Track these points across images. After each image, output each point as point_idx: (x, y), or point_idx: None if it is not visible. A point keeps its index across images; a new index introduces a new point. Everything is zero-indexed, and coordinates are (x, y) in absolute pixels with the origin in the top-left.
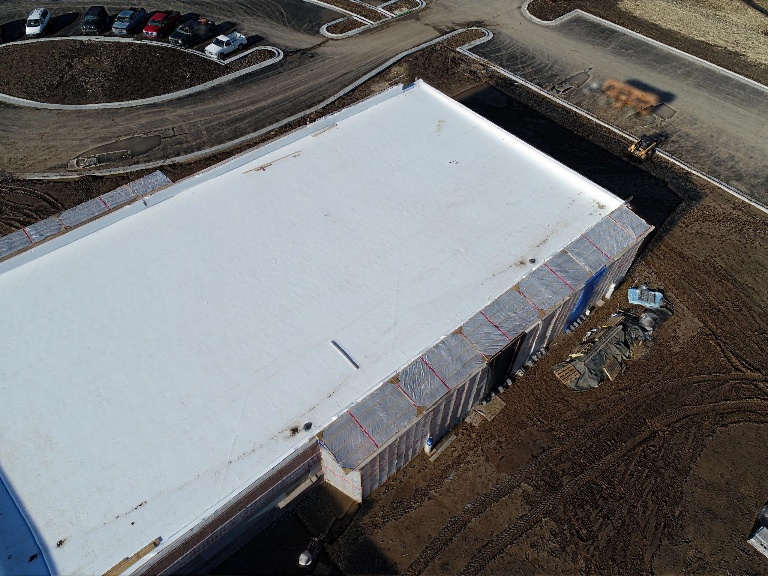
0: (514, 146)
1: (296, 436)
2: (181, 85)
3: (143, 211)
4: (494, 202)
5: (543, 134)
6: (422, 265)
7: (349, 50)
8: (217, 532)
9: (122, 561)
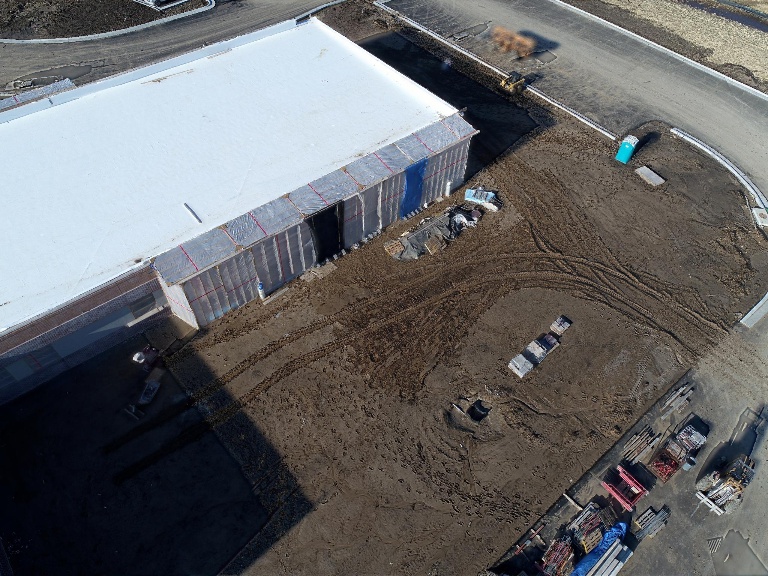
0: (382, 70)
1: None
2: (118, 26)
3: (49, 108)
4: (351, 111)
5: (429, 71)
6: (275, 154)
7: (276, 2)
8: (64, 326)
9: None
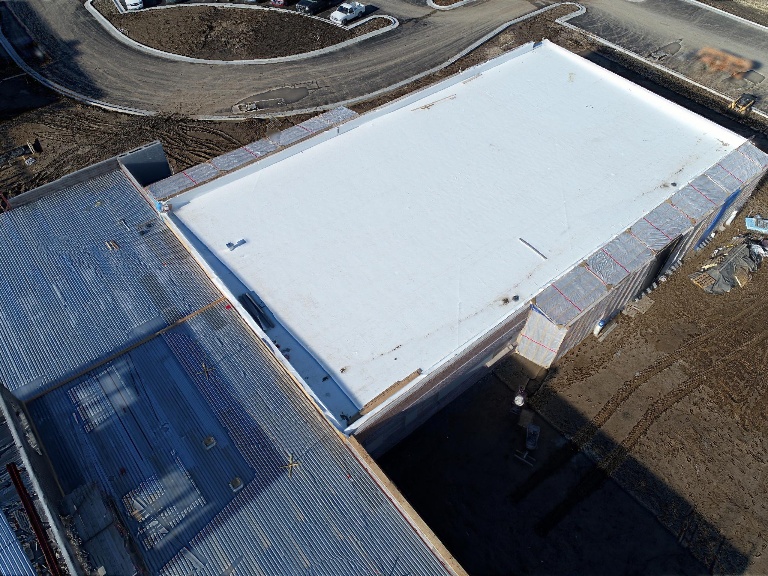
0: (640, 95)
1: (508, 305)
2: (314, 46)
3: (335, 137)
4: (632, 139)
5: None
6: (581, 185)
7: (457, 20)
8: (458, 370)
9: (396, 383)
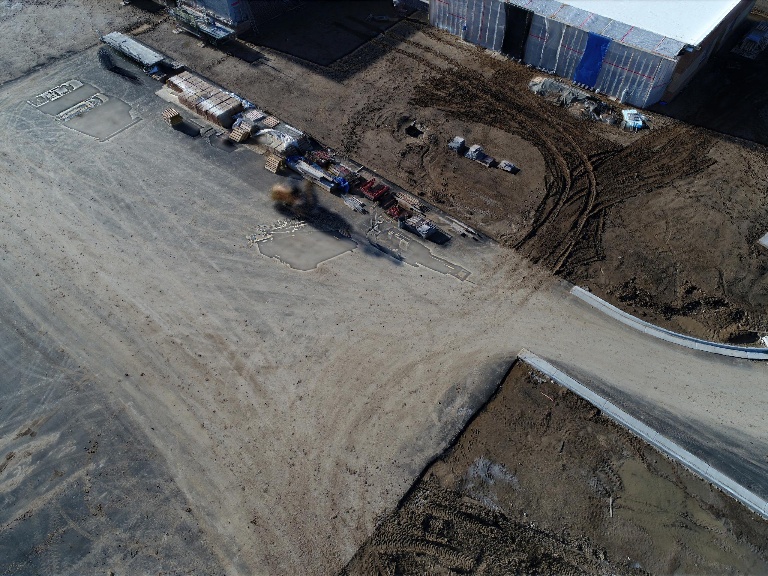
0: None
1: None
2: None
3: None
4: (648, 7)
5: None
6: None
7: None
8: None
9: None
